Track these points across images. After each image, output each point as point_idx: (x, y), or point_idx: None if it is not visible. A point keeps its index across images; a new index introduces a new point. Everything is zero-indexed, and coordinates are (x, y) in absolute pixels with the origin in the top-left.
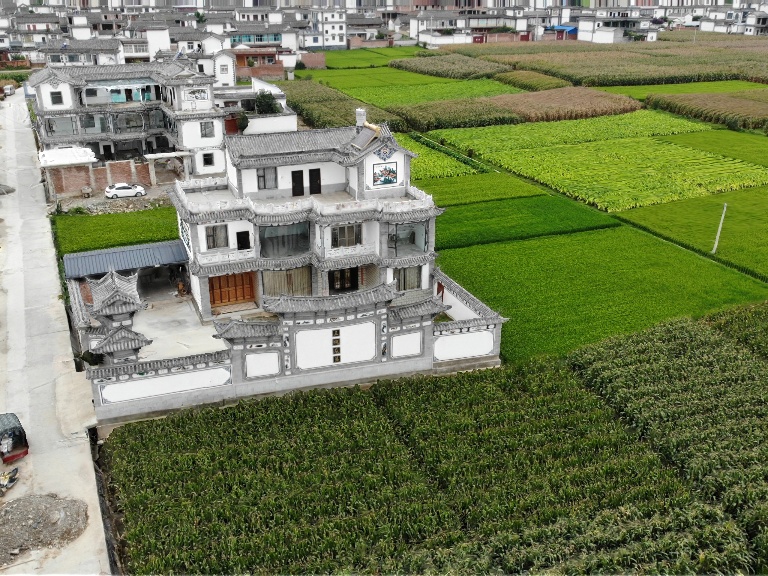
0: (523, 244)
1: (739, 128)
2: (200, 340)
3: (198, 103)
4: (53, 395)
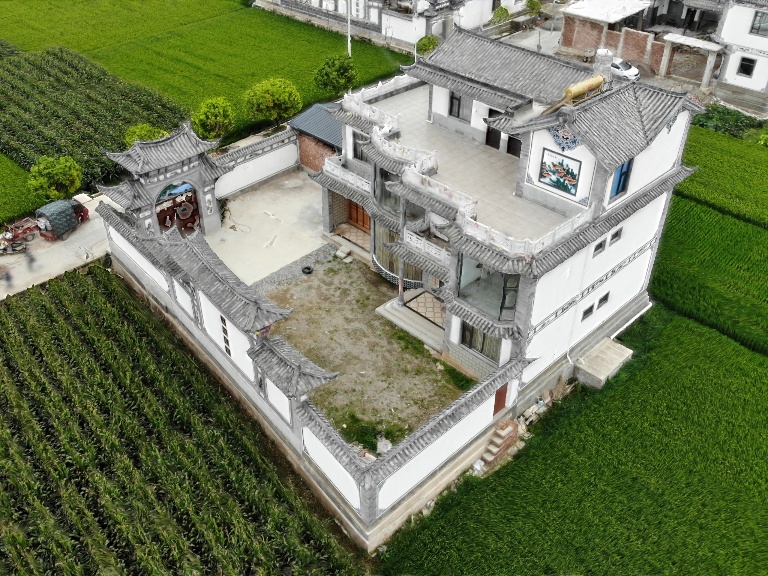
0: None
1: None
2: (287, 247)
3: None
4: None
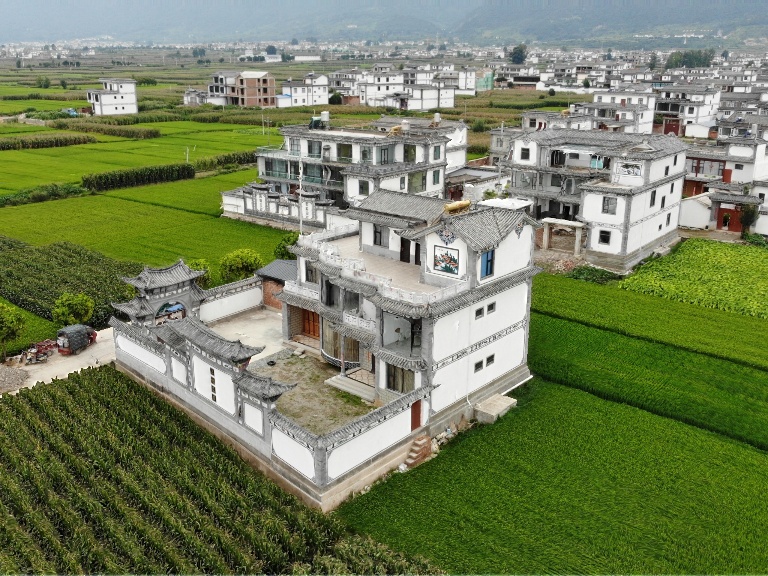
0: (738, 451)
1: None
2: None
3: (629, 178)
4: None
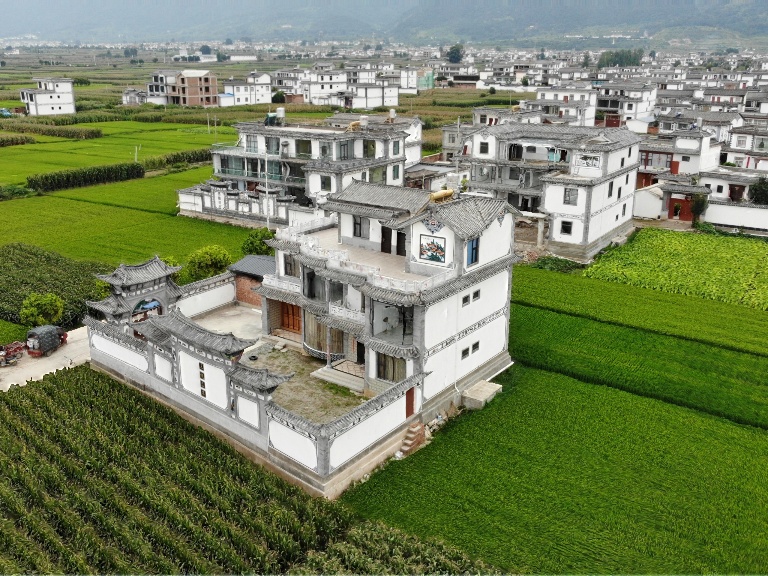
0: (718, 426)
1: None
2: None
3: (588, 170)
4: None
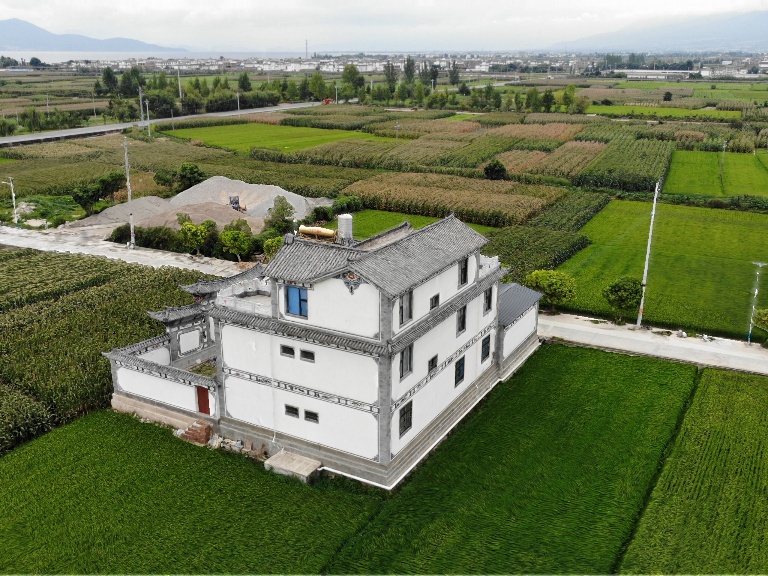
0: None
1: None
2: None
3: None
4: None
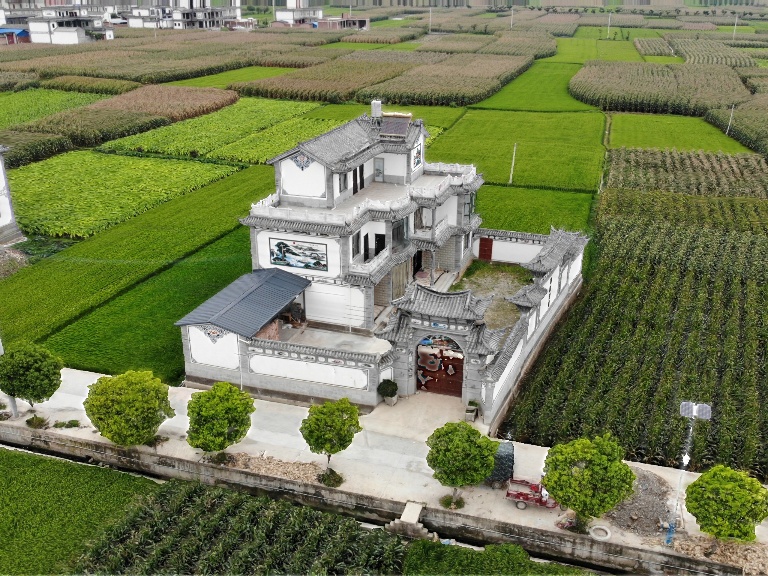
0: None
1: (340, 102)
2: None
3: None
4: (397, 438)
